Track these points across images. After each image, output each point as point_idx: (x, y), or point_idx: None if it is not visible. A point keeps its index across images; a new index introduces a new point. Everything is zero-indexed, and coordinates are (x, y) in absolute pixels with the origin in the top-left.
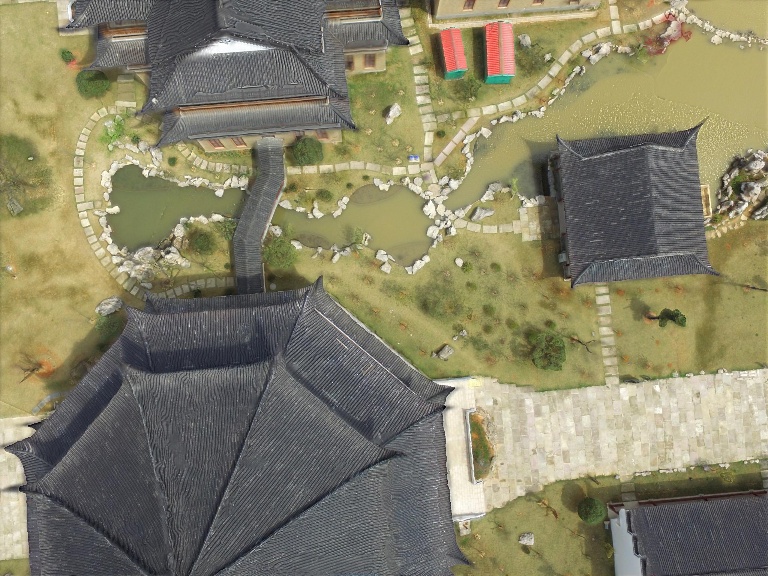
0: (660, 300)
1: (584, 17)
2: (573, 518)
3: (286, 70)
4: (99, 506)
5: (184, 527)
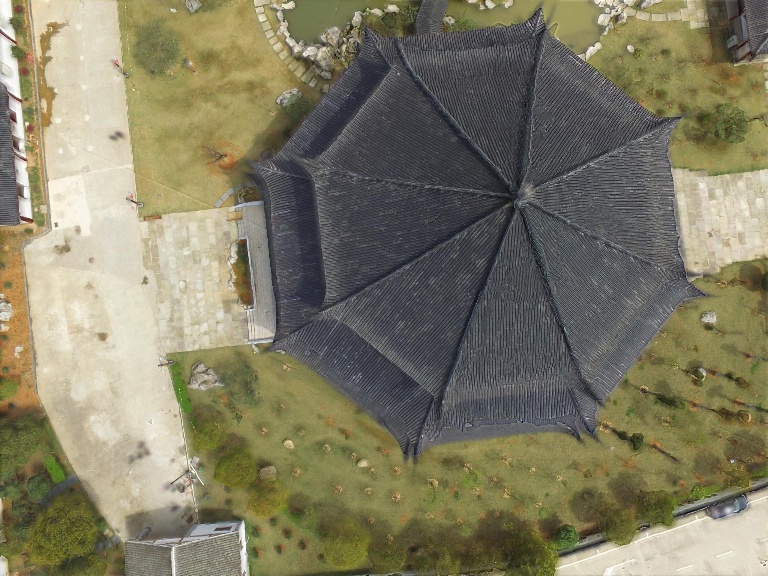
0: None
1: None
2: (752, 297)
3: None
4: (389, 166)
5: (501, 149)
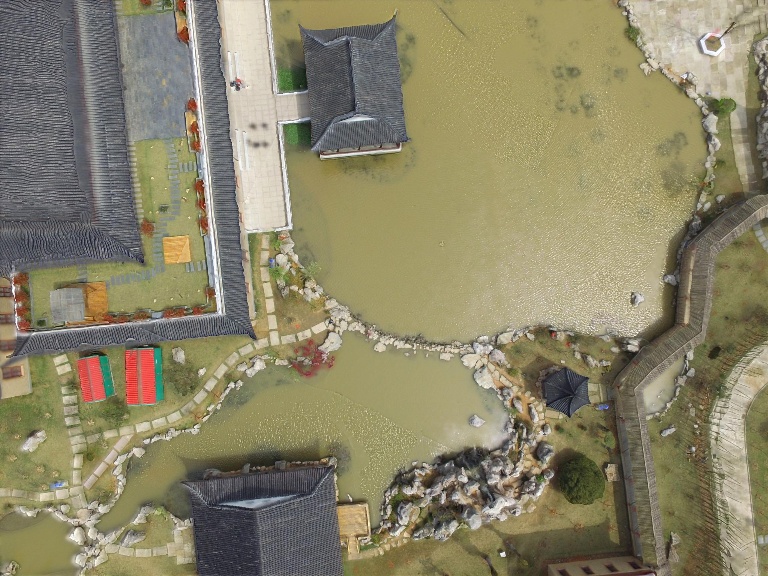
0: None
1: None
2: None
3: None
4: None
5: None
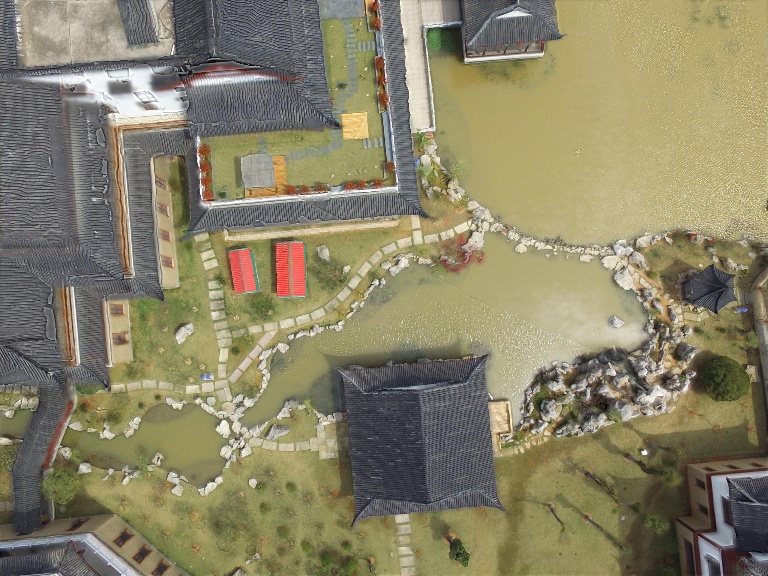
0: (461, 519)
1: (385, 226)
2: None
3: (5, 361)
4: None
5: None
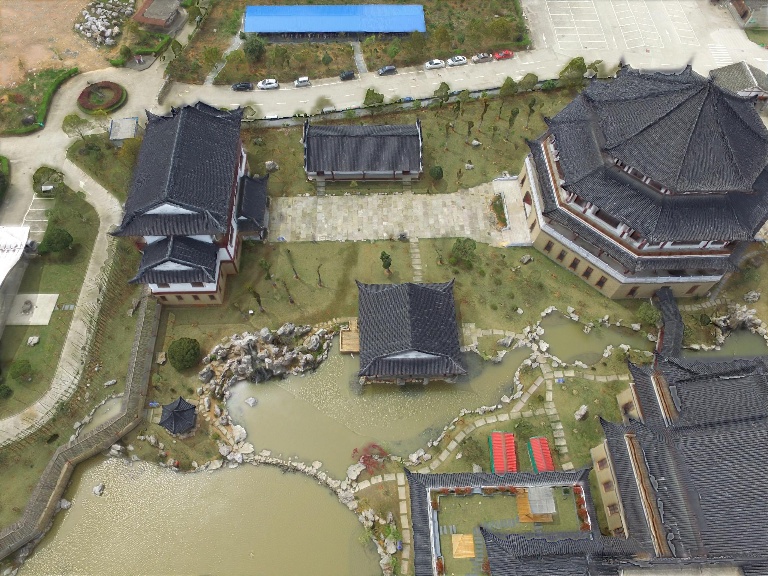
0: (380, 282)
1: None
2: None
3: None
4: None
5: None
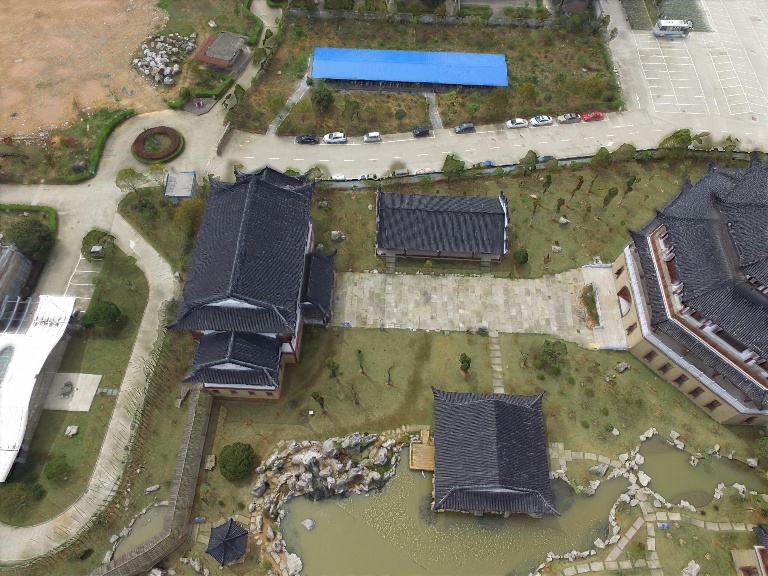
0: (455, 384)
1: None
2: None
3: None
4: None
5: None
